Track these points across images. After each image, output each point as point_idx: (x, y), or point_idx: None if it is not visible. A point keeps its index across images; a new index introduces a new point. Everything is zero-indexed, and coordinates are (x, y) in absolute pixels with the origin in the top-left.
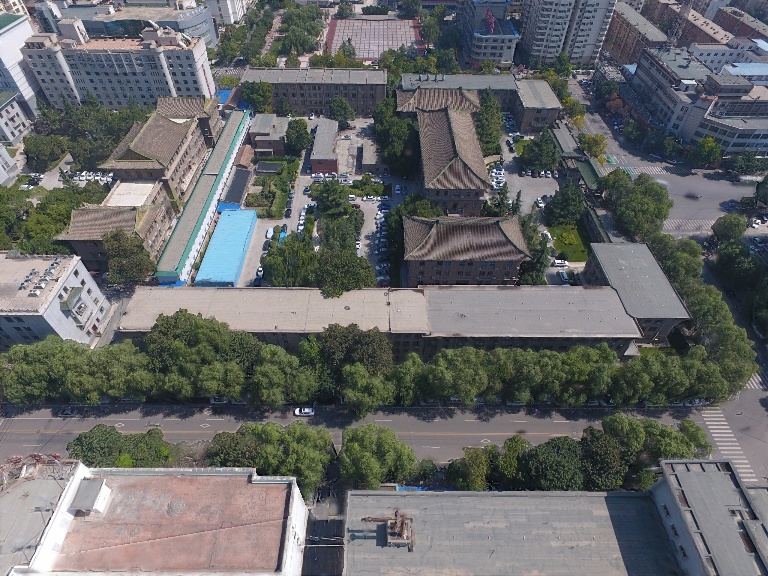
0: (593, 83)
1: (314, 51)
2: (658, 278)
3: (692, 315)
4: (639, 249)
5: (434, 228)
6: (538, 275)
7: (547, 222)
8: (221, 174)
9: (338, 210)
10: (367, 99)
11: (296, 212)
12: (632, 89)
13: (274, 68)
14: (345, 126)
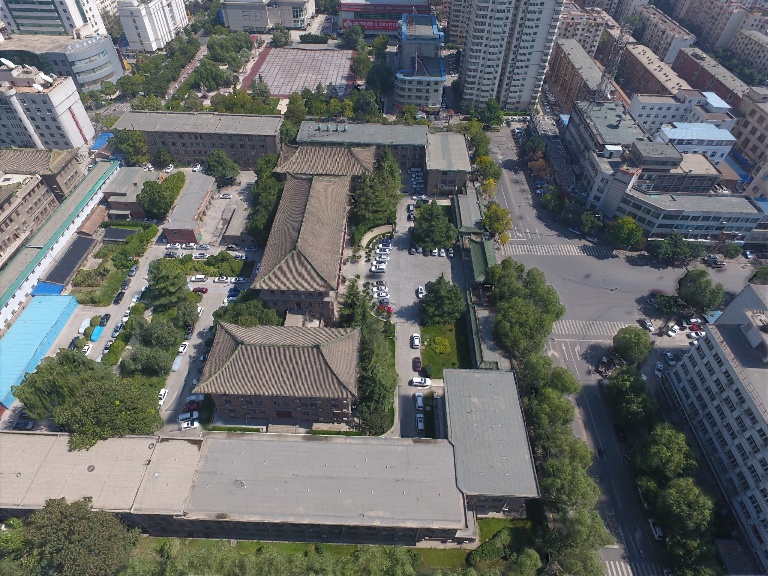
0: (527, 133)
1: (231, 85)
2: (513, 428)
3: (542, 491)
4: (502, 380)
5: (238, 350)
6: (377, 407)
7: (421, 320)
8: (47, 247)
9: (168, 300)
10: (257, 150)
11: (130, 296)
12: (563, 145)
13: (157, 112)
14: (229, 181)
